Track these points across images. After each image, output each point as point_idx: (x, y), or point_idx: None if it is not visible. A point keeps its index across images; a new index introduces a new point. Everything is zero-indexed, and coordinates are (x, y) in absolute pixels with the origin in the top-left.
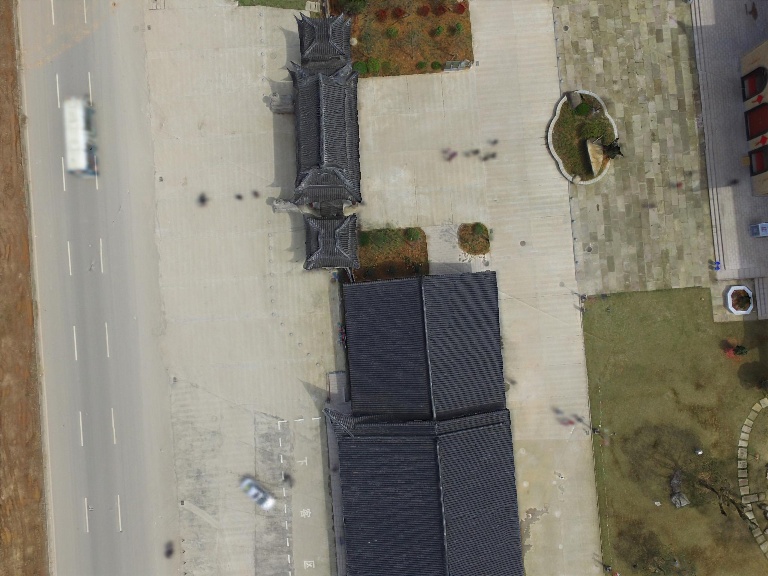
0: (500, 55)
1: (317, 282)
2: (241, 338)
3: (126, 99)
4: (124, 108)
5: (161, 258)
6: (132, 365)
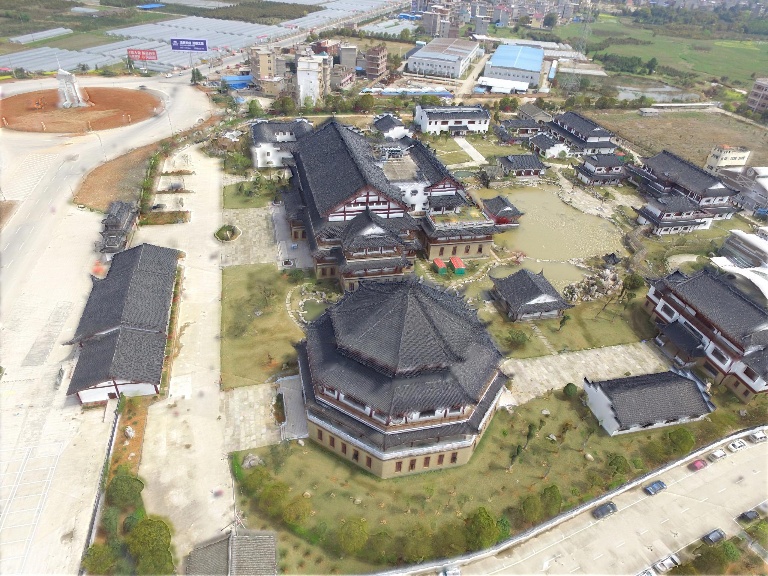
0: (201, 220)
1: (107, 267)
2: (63, 282)
3: (46, 231)
4: (44, 233)
5: (38, 264)
6: (5, 290)
